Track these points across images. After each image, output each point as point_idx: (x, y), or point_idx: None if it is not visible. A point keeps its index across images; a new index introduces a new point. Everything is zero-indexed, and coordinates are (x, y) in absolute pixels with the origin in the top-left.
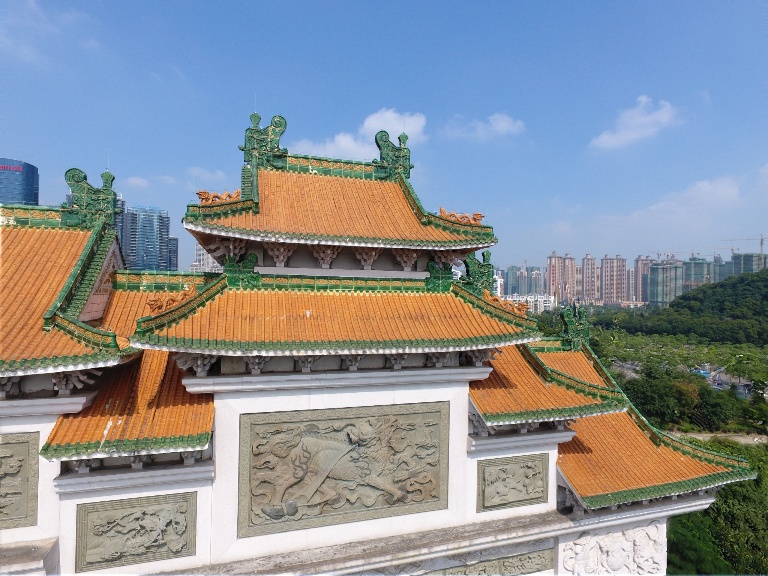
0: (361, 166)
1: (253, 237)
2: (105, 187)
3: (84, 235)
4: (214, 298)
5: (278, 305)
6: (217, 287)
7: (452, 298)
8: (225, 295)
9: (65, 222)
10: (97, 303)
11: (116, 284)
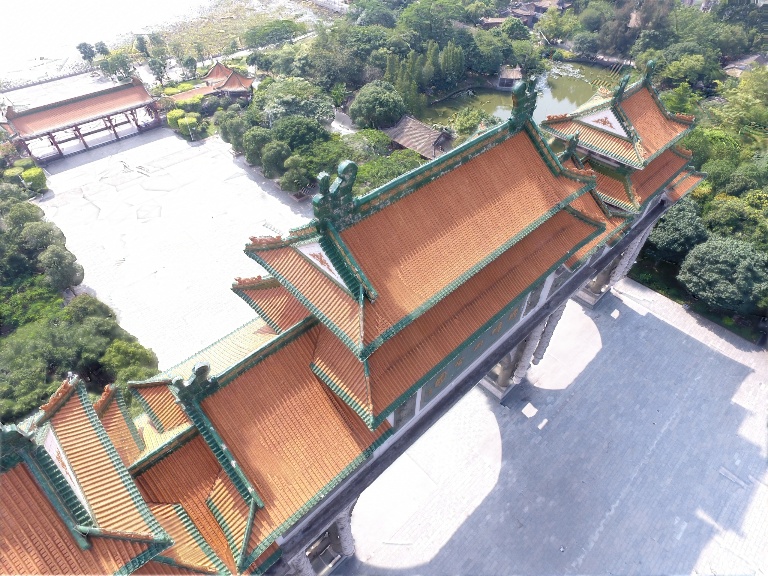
0: None
1: None
2: None
3: None
4: None
5: None
6: None
7: None
8: None
9: None
10: None
11: None
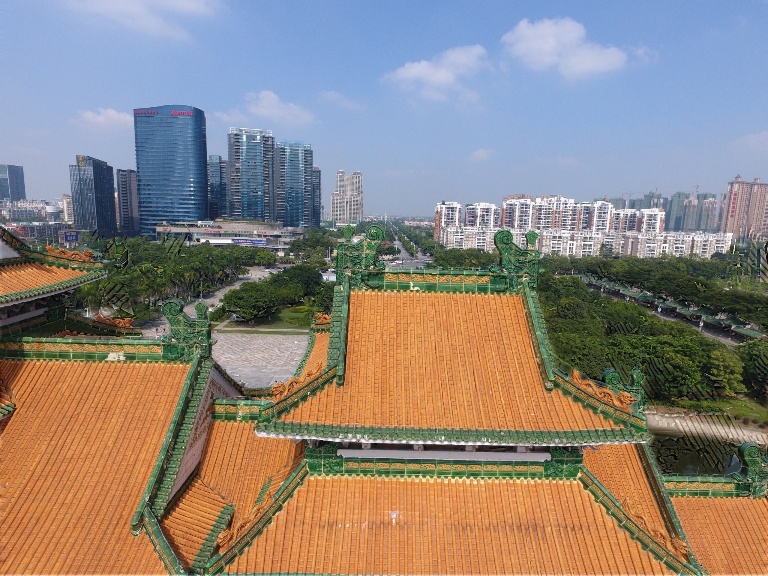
0: (474, 277)
1: (331, 439)
2: (199, 319)
3: (183, 370)
4: (293, 494)
5: (361, 502)
6: (296, 479)
7: (579, 490)
8: (305, 486)
9: (166, 356)
10: (193, 454)
11: (215, 415)
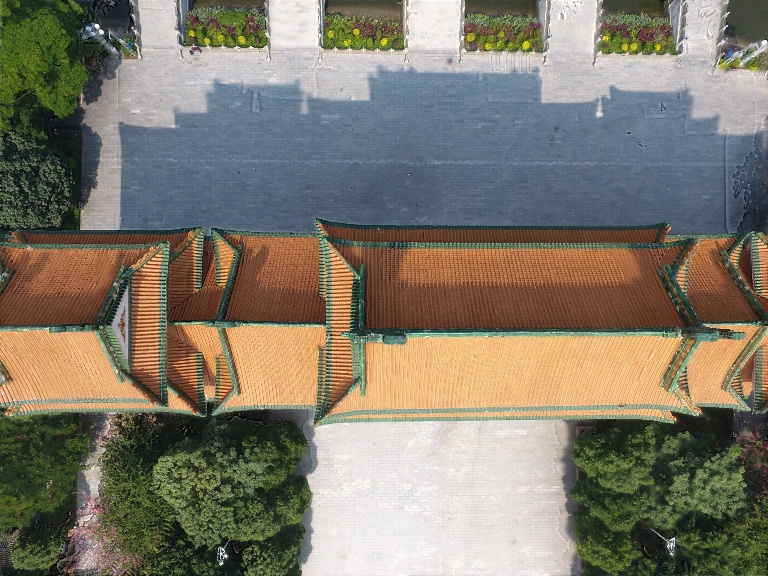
0: None
1: None
2: None
3: (752, 328)
4: None
5: None
6: None
7: None
8: None
9: None
10: None
11: None
